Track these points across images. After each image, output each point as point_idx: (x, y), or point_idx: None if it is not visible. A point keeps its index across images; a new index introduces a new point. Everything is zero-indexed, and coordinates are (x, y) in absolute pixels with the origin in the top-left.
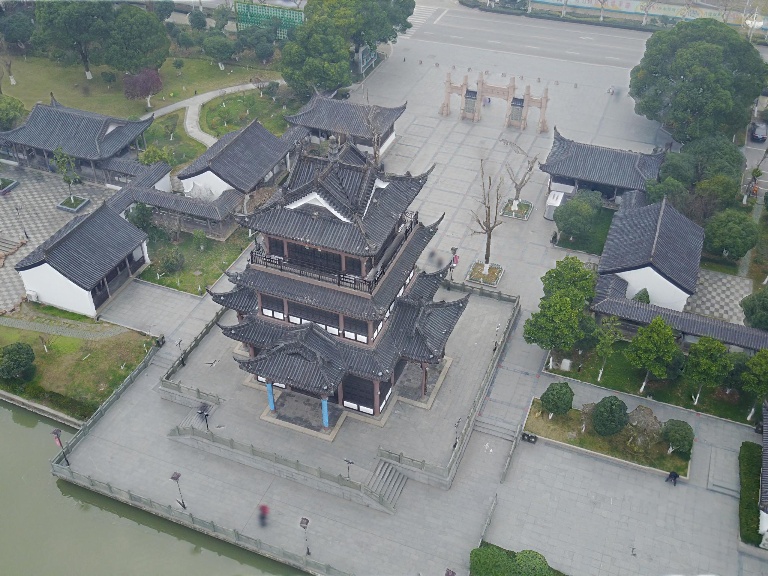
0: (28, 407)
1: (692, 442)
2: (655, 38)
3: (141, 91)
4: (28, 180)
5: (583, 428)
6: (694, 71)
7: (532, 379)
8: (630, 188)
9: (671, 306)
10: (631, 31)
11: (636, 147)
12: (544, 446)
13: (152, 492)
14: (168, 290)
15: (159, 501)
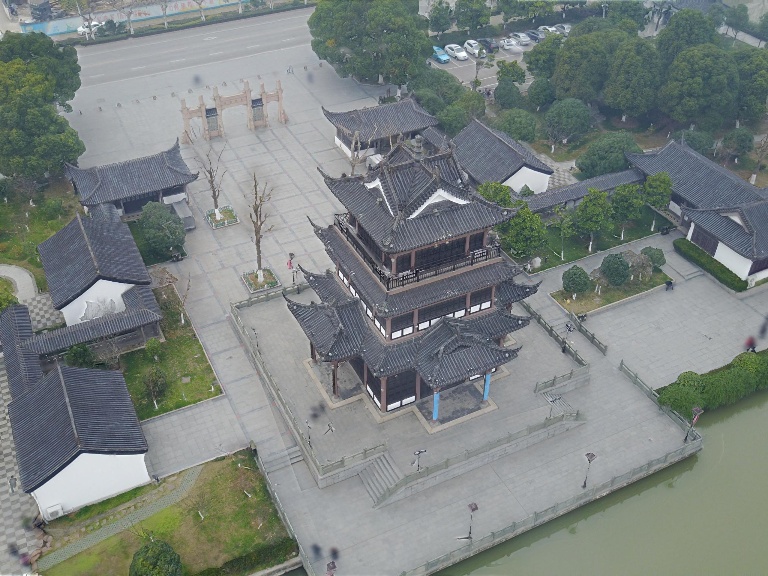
0: None
1: None
2: (326, 10)
3: None
4: None
5: (599, 291)
6: (397, 22)
7: None
8: (424, 128)
9: (540, 190)
10: (237, 21)
11: (363, 104)
12: (592, 318)
13: (431, 552)
14: (182, 411)
15: (446, 552)
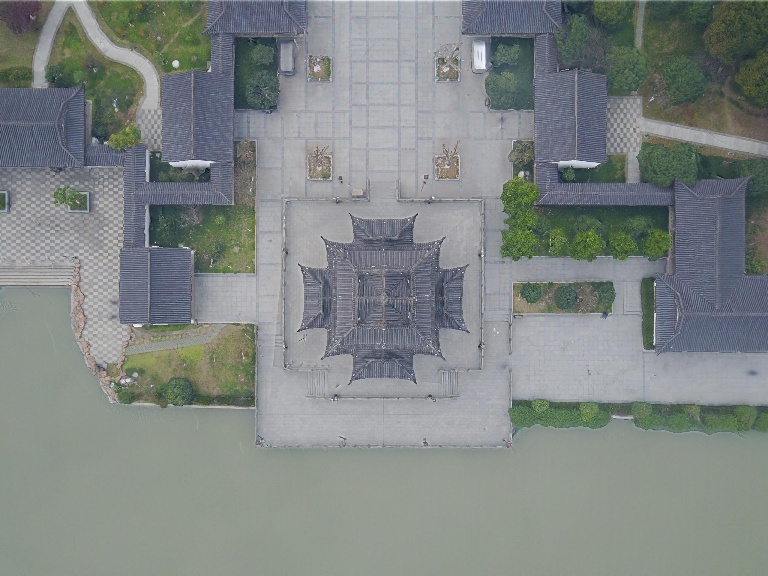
0: None
1: (613, 284)
2: None
3: None
4: (12, 184)
5: None
6: None
7: (508, 266)
8: (541, 33)
9: None
10: None
11: None
12: (528, 318)
13: (322, 437)
14: (226, 276)
15: (329, 441)
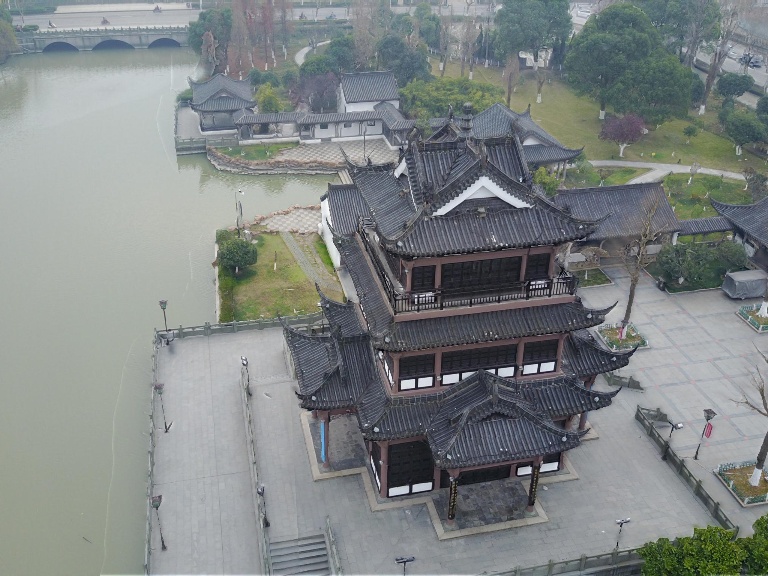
0: None
1: None
2: None
3: (615, 134)
4: None
5: None
6: None
7: None
8: None
9: None
10: None
11: None
12: None
13: (171, 403)
14: None
15: (164, 412)
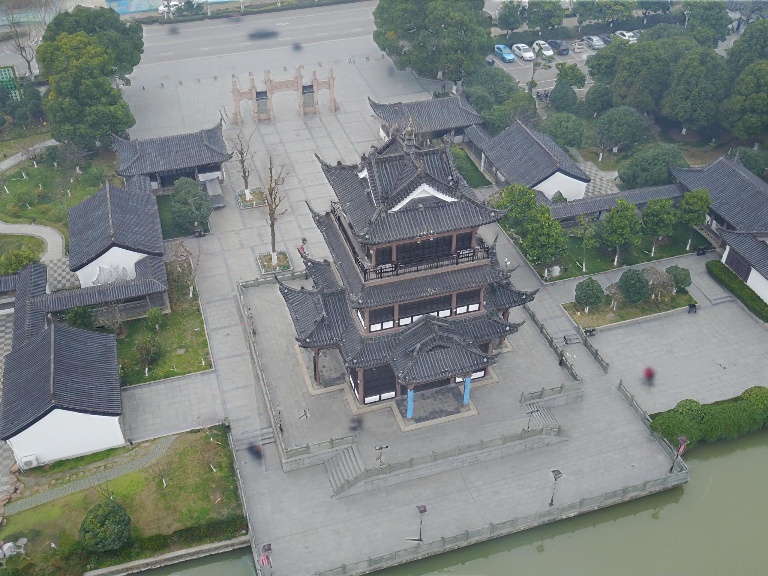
0: (154, 565)
1: None
2: (389, 2)
3: None
4: None
5: (614, 307)
6: (455, 17)
7: (545, 293)
8: (468, 125)
9: (576, 198)
10: (311, 9)
11: (416, 98)
12: (602, 334)
13: (378, 548)
14: (170, 381)
15: None
